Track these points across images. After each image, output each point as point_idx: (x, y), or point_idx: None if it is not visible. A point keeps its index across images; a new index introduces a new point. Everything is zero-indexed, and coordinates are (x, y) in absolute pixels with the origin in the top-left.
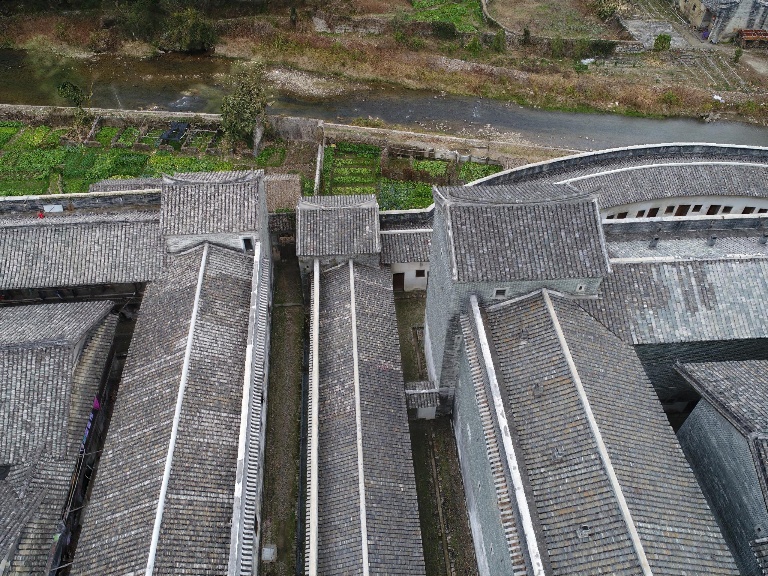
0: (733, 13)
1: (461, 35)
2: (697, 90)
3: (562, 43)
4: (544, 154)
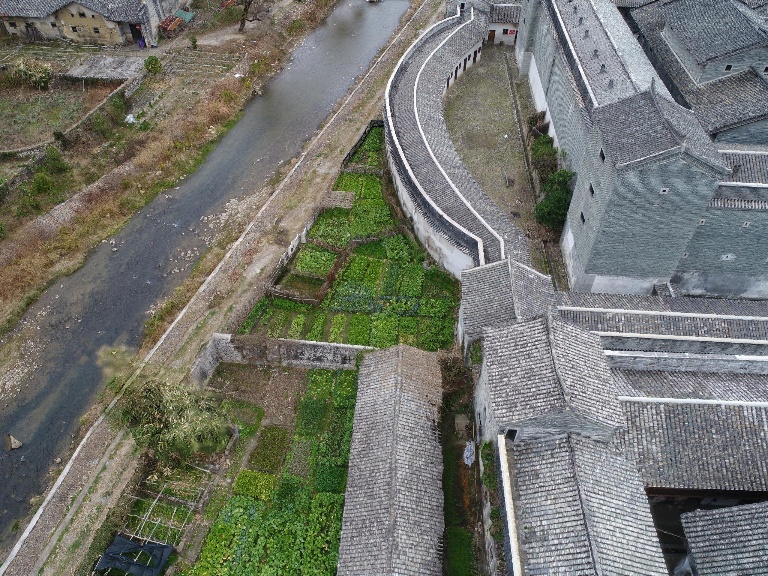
0: (148, 15)
1: (5, 188)
2: (224, 80)
3: (105, 118)
4: (309, 182)
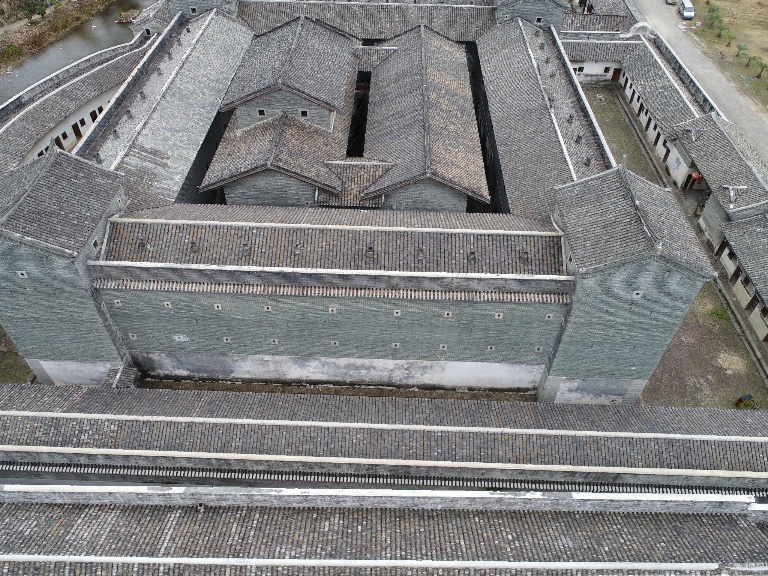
0: None
1: None
2: None
3: None
4: None
